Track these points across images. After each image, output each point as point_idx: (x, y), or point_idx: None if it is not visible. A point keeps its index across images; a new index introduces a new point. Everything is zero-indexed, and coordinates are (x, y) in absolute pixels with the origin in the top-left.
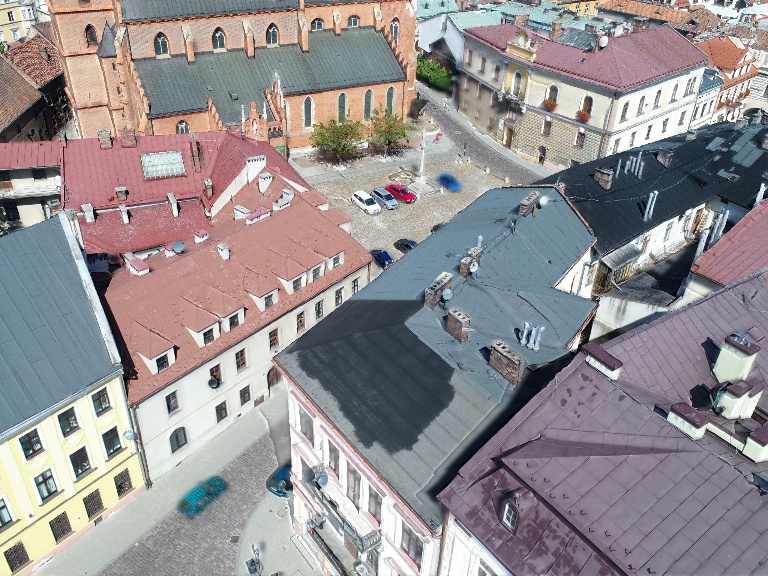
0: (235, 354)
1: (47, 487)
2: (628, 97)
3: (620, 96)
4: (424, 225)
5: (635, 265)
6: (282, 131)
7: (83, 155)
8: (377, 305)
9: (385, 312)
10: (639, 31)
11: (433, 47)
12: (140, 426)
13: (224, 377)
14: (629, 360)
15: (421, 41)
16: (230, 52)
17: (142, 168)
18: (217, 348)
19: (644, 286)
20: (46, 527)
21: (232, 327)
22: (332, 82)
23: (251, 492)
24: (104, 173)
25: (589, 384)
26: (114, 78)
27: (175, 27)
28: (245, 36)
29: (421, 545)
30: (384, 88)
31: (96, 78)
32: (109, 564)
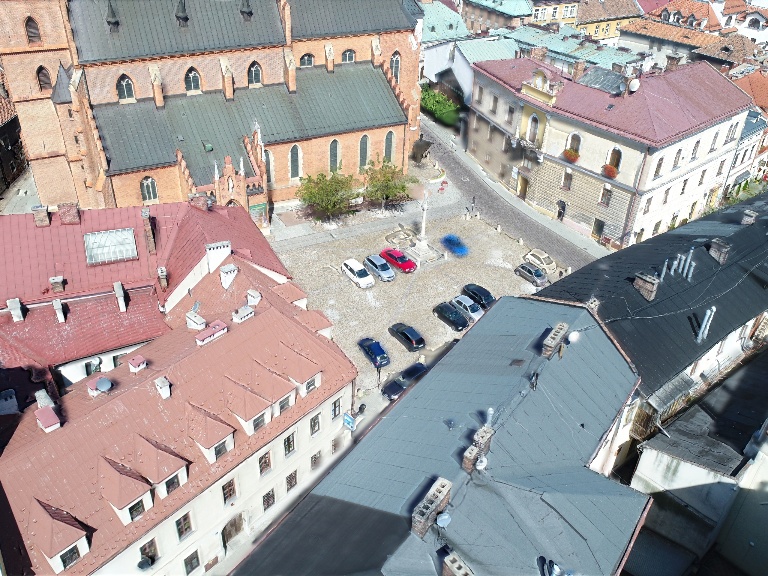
0: (175, 522)
1: None
2: (663, 151)
3: (654, 151)
4: (424, 302)
5: (684, 396)
6: (263, 188)
7: (14, 235)
8: (347, 515)
9: (356, 535)
10: (673, 69)
11: (439, 77)
12: None
13: (161, 551)
14: None
15: (426, 69)
16: (206, 94)
17: (85, 250)
18: (148, 522)
19: (699, 431)
20: None
21: (170, 490)
22: (322, 127)
23: None
24: (38, 257)
25: None
26: (71, 126)
27: (141, 68)
28: (223, 76)
29: None
30: (382, 133)
31: (51, 125)
32: None
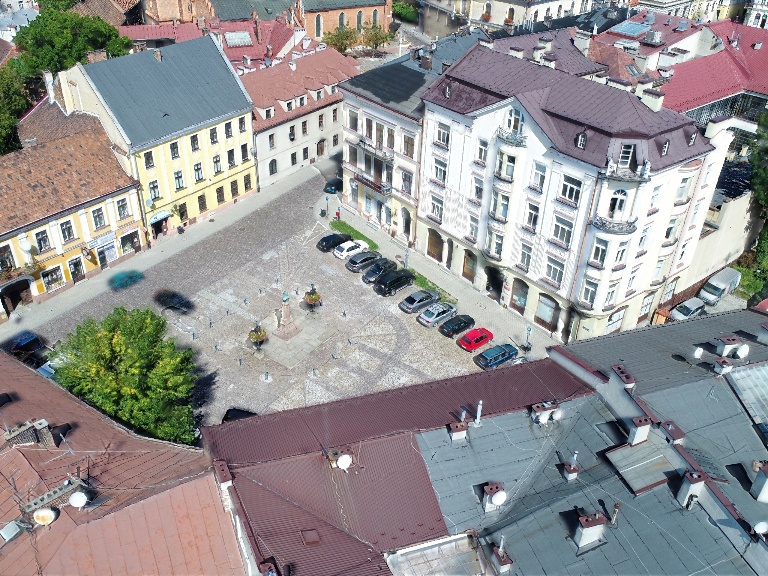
0: (302, 123)
1: (217, 166)
2: (537, 7)
3: (531, 5)
4: None
5: None
6: None
7: (188, 33)
8: None
9: (390, 65)
10: None
11: None
12: (257, 149)
13: (296, 136)
14: (499, 48)
15: None
16: None
17: (225, 41)
18: (294, 114)
19: None
20: (215, 191)
21: (301, 105)
22: (335, 4)
23: (316, 193)
24: None
25: (481, 51)
26: None
27: None
28: None
29: (413, 143)
30: (371, 10)
31: None
32: (247, 215)
